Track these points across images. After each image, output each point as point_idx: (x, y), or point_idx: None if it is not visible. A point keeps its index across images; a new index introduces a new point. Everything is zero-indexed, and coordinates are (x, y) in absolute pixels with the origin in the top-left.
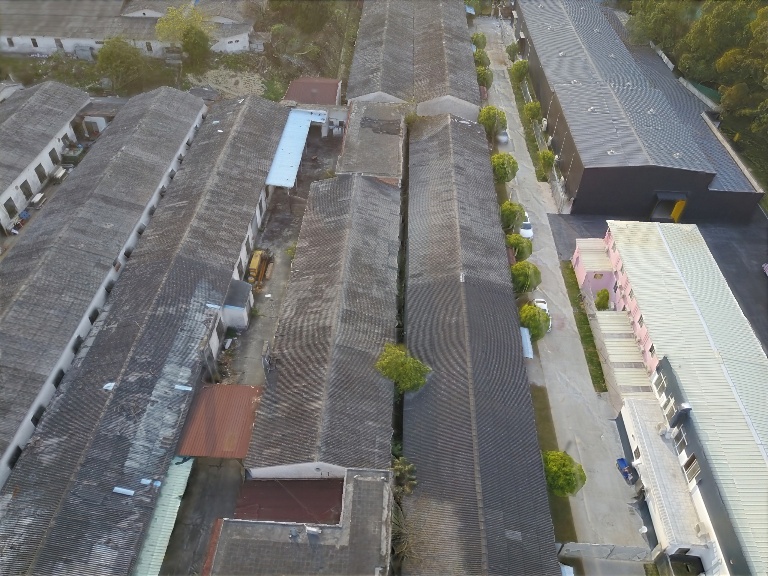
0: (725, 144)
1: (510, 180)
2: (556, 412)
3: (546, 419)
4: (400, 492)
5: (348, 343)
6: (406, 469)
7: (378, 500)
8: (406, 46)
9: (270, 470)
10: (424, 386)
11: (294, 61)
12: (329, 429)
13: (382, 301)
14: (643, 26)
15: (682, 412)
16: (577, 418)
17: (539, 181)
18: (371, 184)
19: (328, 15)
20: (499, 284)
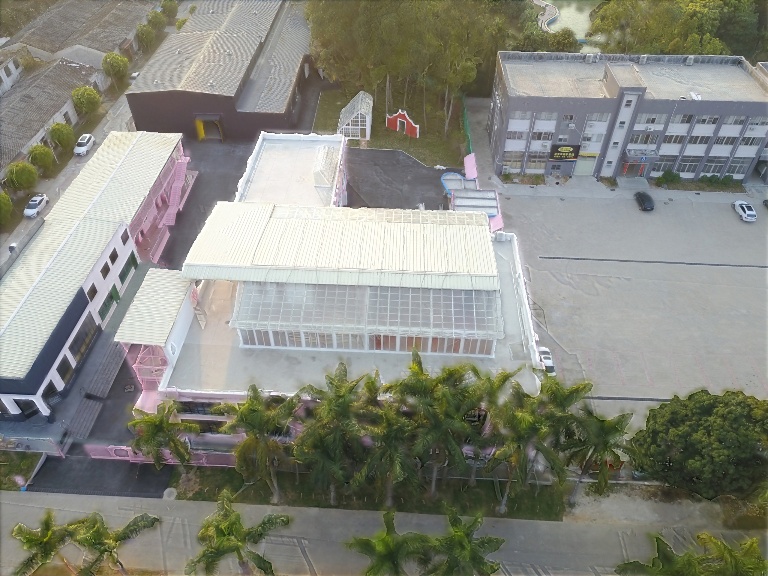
0: None
1: (92, 110)
2: None
3: None
4: None
5: None
6: None
7: None
8: (90, 9)
9: None
10: None
11: None
12: None
13: None
14: None
15: (10, 250)
16: None
17: None
18: None
19: None
20: None
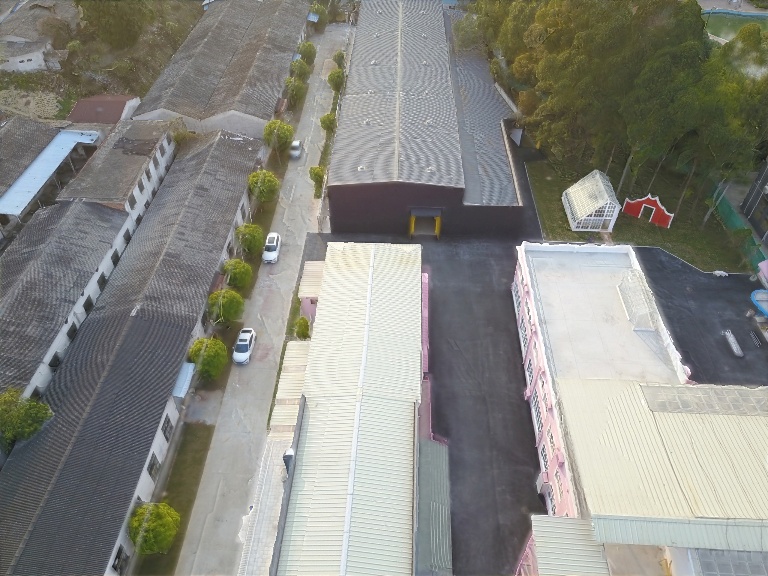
0: (508, 154)
1: (271, 199)
2: (213, 454)
3: (198, 462)
4: None
5: None
6: None
7: None
8: (222, 58)
9: None
10: (36, 433)
11: (99, 78)
12: None
13: (35, 339)
14: (467, 30)
15: (285, 459)
16: (232, 460)
17: (315, 198)
18: (91, 210)
19: (136, 29)
20: (180, 316)
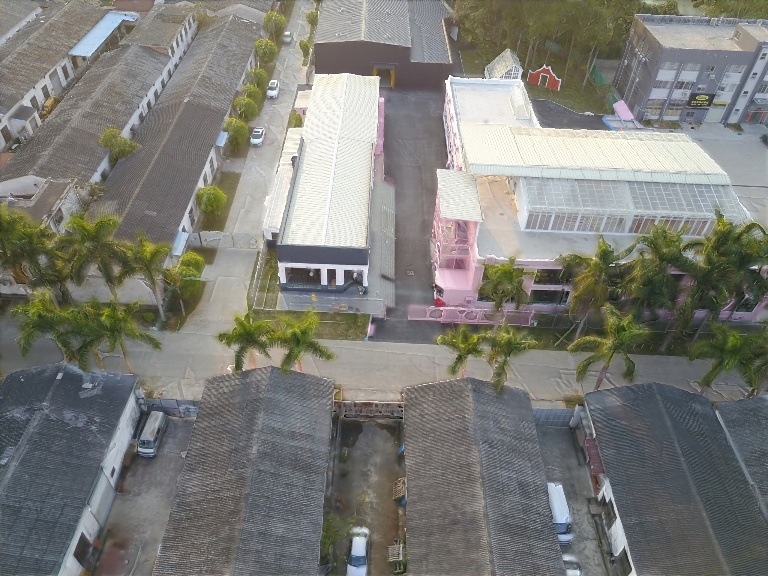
0: (446, 37)
1: (271, 60)
2: (241, 185)
3: (232, 188)
4: (90, 199)
5: (81, 127)
6: (96, 187)
7: (61, 190)
8: None
9: (5, 187)
10: (132, 154)
11: None
12: (46, 163)
13: (121, 111)
14: None
15: (293, 160)
16: (254, 188)
17: (303, 66)
18: (145, 51)
19: None
20: (216, 107)
